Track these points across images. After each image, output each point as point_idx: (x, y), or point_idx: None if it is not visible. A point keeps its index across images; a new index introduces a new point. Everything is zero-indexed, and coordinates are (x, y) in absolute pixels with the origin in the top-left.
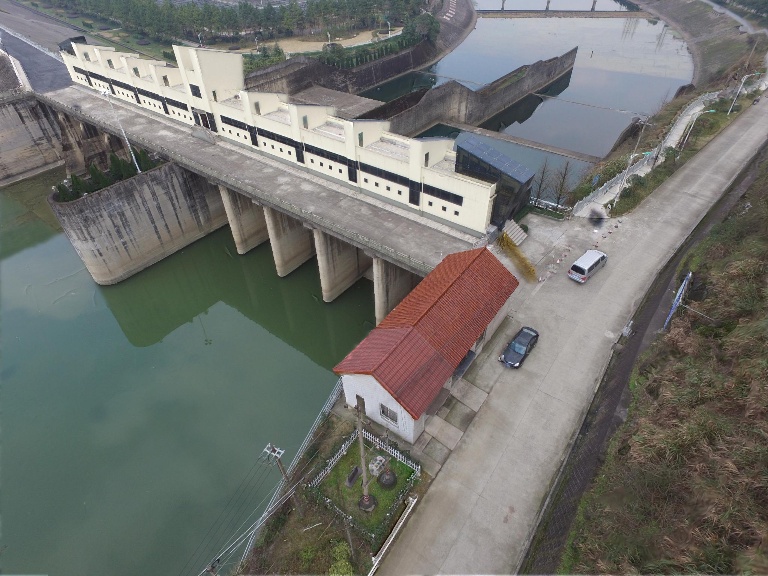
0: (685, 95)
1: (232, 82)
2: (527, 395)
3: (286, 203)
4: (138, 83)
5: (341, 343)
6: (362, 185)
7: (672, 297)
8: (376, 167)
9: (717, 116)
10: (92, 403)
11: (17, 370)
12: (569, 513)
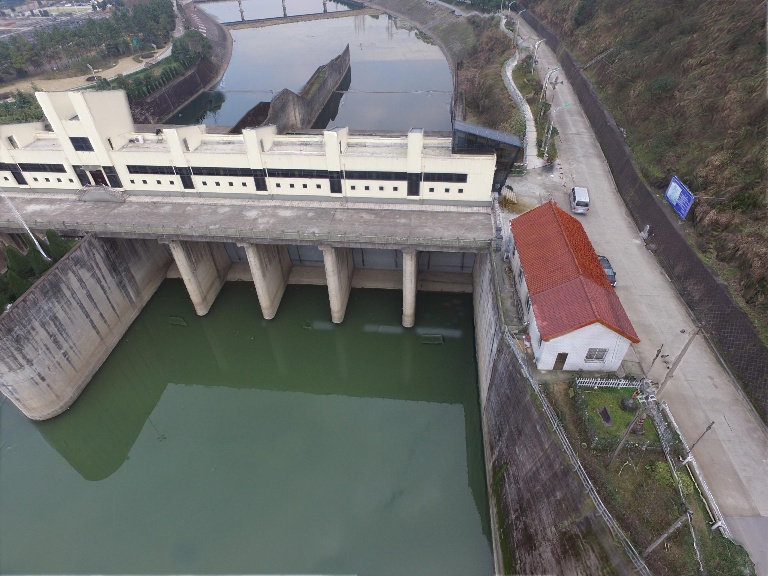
0: (491, 66)
1: (123, 125)
2: (638, 302)
3: (291, 232)
4: None
5: (354, 360)
6: (348, 194)
7: (661, 199)
8: (366, 171)
9: None
10: (166, 547)
11: (13, 574)
12: (760, 354)
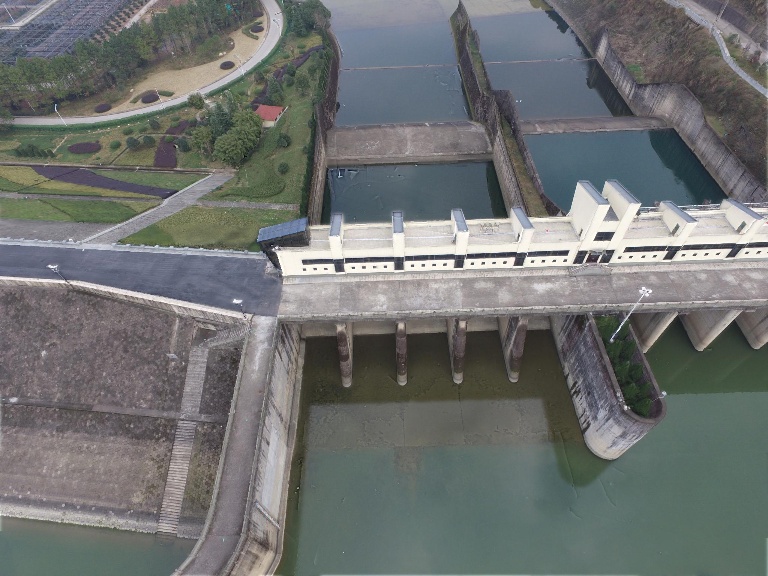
0: (710, 58)
1: None
2: None
3: None
4: (476, 249)
5: (739, 369)
6: None
7: None
8: None
9: (764, 76)
10: None
11: (710, 573)
12: None
